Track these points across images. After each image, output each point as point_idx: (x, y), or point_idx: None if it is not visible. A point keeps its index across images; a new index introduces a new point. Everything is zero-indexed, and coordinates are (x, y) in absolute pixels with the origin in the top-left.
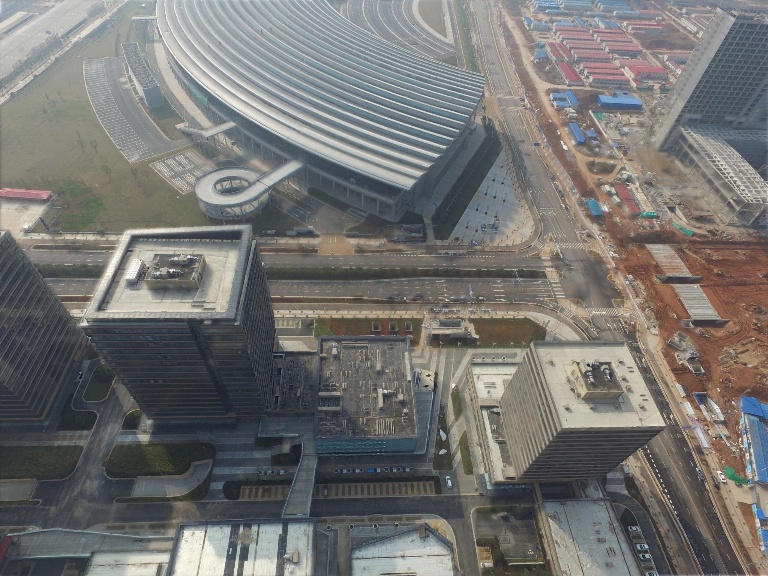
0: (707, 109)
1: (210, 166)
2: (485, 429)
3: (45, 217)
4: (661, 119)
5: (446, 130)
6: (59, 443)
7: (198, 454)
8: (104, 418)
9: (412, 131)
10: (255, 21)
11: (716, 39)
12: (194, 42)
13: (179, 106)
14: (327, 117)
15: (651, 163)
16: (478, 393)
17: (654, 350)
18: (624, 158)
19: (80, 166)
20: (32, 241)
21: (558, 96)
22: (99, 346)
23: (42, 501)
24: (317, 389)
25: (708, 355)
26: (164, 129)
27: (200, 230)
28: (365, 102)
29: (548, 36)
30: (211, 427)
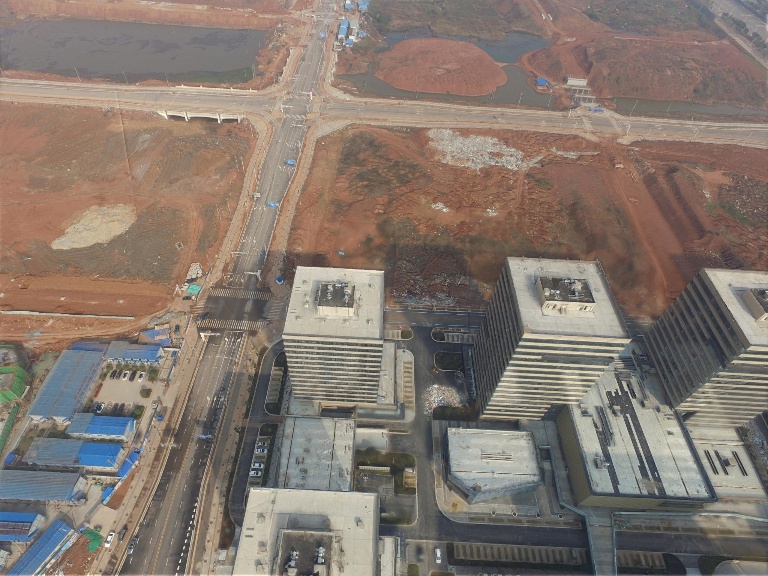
0: None
1: None
2: None
3: None
4: None
5: None
6: None
7: None
8: None
9: None
10: None
11: None
12: None
13: None
14: None
15: None
16: None
17: None
18: None
19: None
20: None
21: None
22: None
23: None
24: None
25: None
26: None
27: None
28: None
29: None
30: None
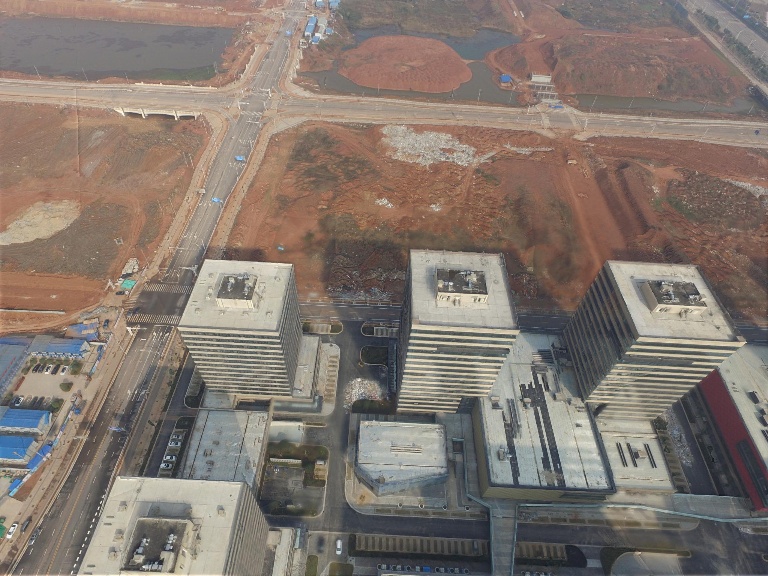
0: None
1: None
2: None
3: None
4: None
5: None
6: None
7: None
8: None
9: None
10: None
11: None
12: None
13: None
14: None
15: None
16: None
17: None
18: None
19: None
20: None
21: None
22: None
23: (763, 559)
24: None
25: None
26: None
27: None
28: None
29: None
30: None
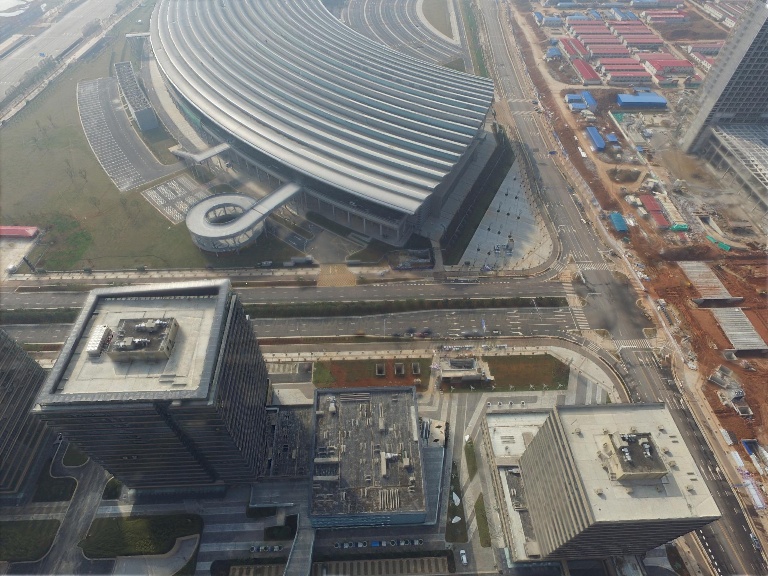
0: (741, 107)
1: (204, 192)
2: (503, 494)
3: (31, 255)
4: (689, 119)
5: (452, 145)
6: (34, 517)
7: (183, 530)
8: (84, 486)
9: (416, 147)
10: (249, 34)
11: (750, 31)
12: (186, 59)
13: (173, 127)
14: (324, 136)
15: (679, 168)
16: (495, 450)
17: (693, 388)
18: (649, 164)
19: (69, 197)
20: (16, 283)
21: (574, 97)
22: (59, 428)
23: None
24: (312, 454)
25: (756, 393)
26: (157, 153)
27: (172, 287)
28: (365, 117)
29: (561, 32)
30: (198, 496)
